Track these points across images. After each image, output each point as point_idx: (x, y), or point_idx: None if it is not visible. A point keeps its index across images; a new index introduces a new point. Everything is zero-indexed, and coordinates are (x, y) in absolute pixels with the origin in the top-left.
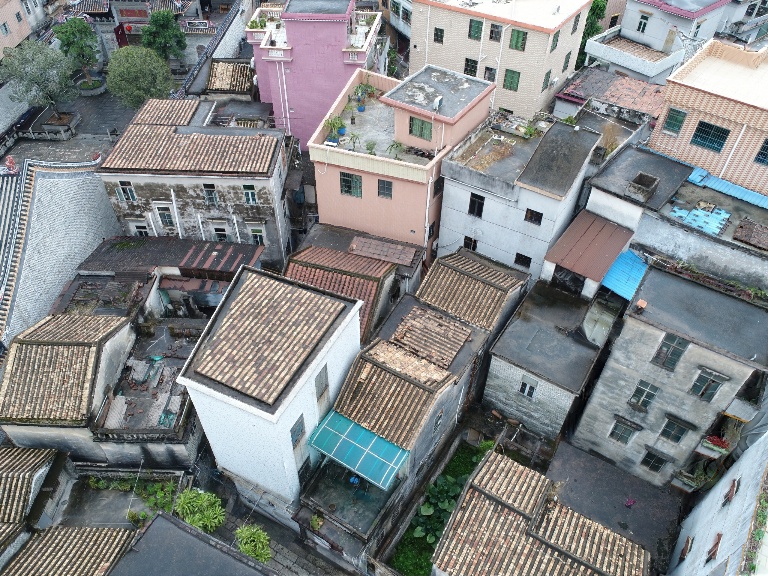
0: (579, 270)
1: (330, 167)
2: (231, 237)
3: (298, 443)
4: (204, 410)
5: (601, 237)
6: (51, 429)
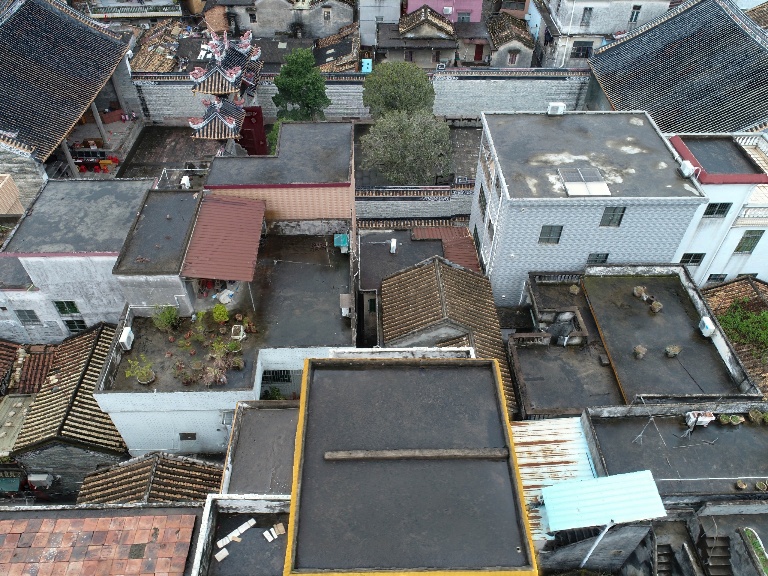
0: None
1: None
2: None
3: None
4: None
5: None
6: None
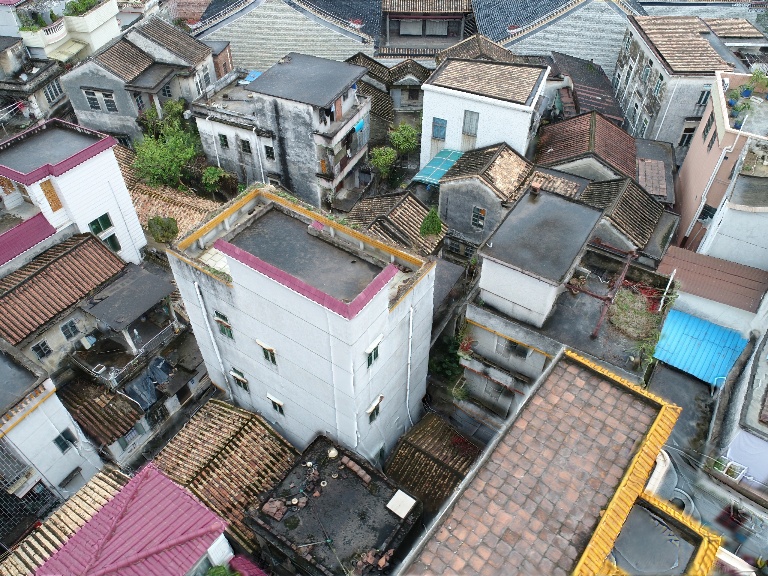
0: (664, 268)
1: None
2: (636, 116)
3: (437, 140)
4: None
5: (729, 286)
6: None
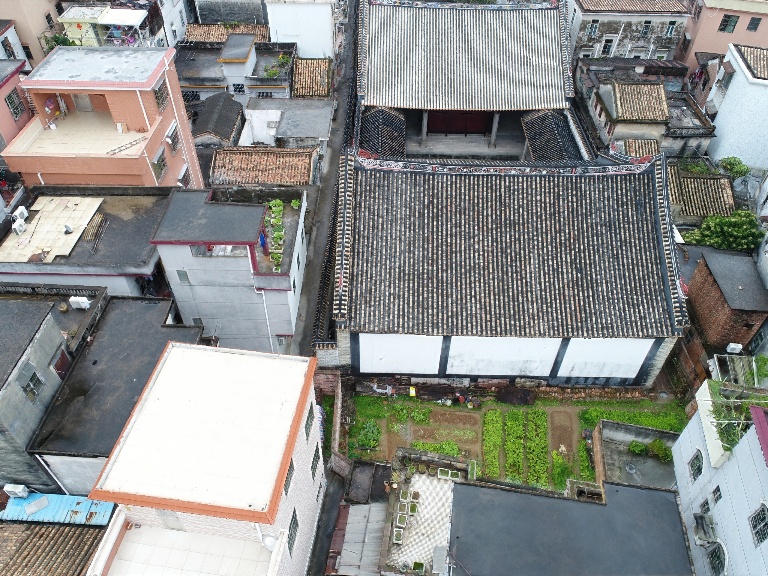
0: None
1: (718, 11)
2: None
3: None
4: (750, 104)
5: None
6: (643, 128)
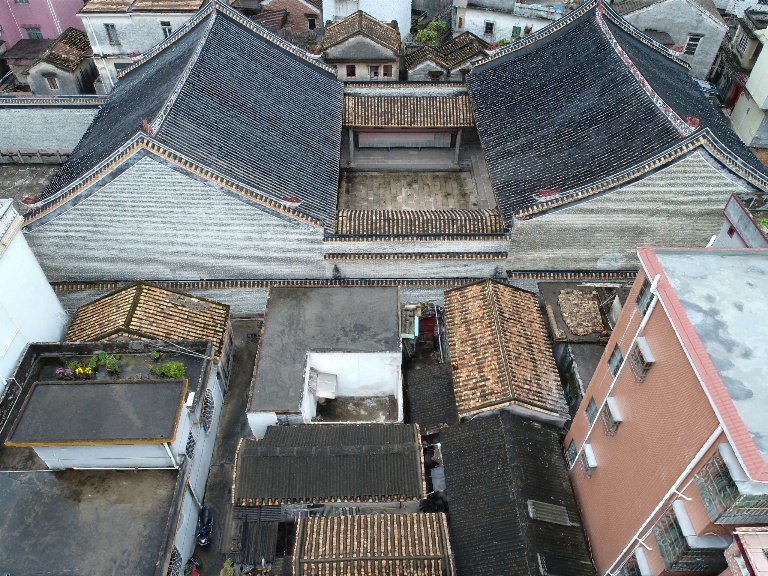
0: None
1: None
2: None
3: None
4: None
5: None
6: None
